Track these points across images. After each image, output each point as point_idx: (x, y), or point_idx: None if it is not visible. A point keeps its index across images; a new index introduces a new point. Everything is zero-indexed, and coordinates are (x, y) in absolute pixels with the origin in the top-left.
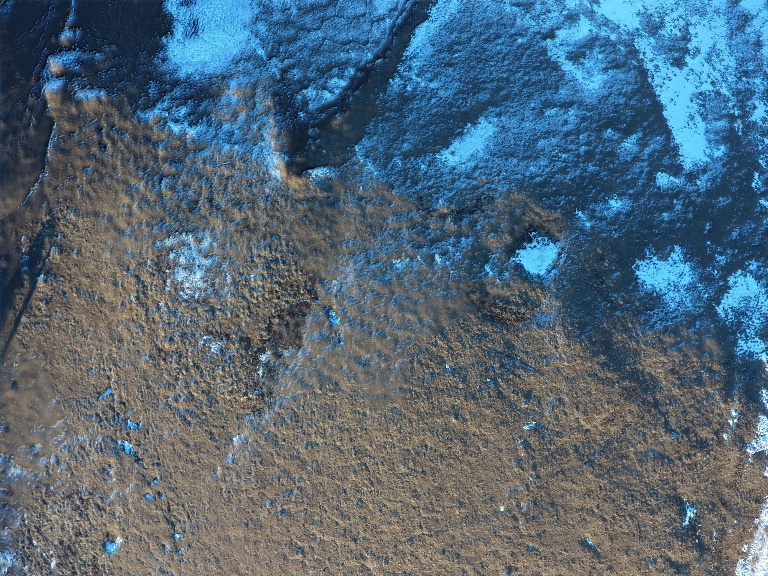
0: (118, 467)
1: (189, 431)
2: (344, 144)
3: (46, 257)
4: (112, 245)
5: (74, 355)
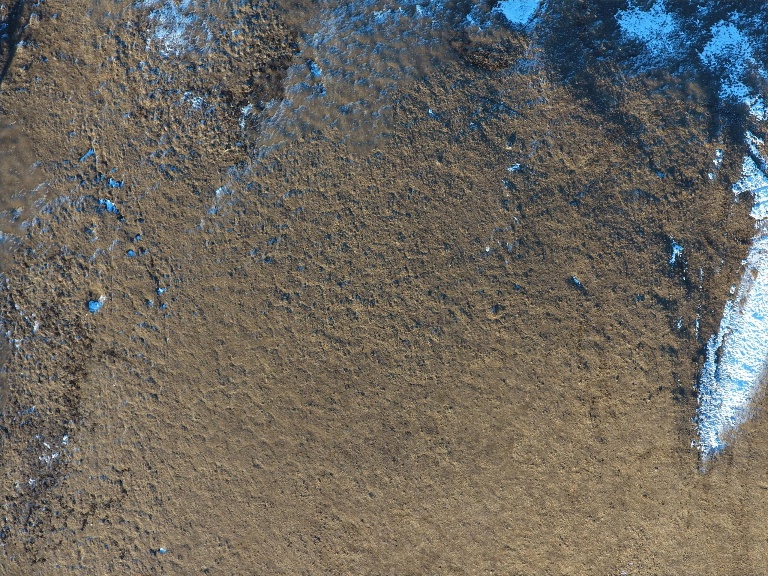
0: (100, 225)
1: (171, 185)
2: None
3: (25, 24)
4: (92, 8)
5: (55, 118)
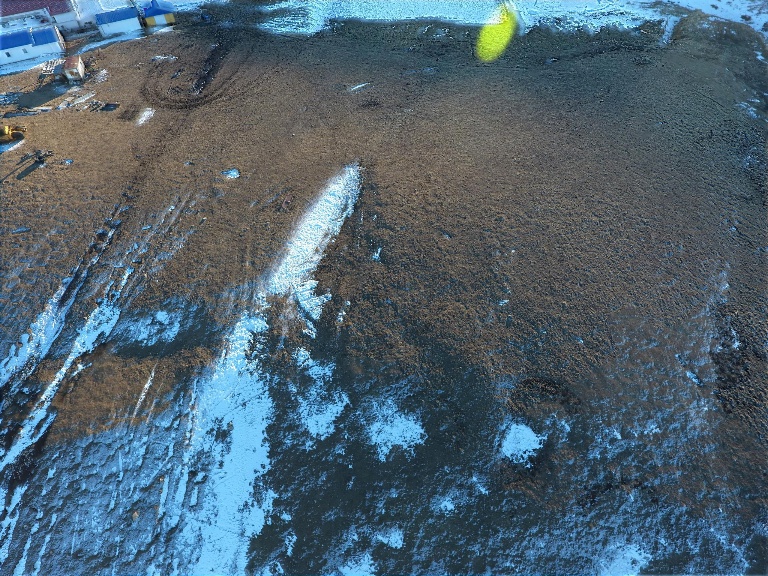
0: None
1: (766, 289)
2: (762, 567)
3: None
4: None
5: None
